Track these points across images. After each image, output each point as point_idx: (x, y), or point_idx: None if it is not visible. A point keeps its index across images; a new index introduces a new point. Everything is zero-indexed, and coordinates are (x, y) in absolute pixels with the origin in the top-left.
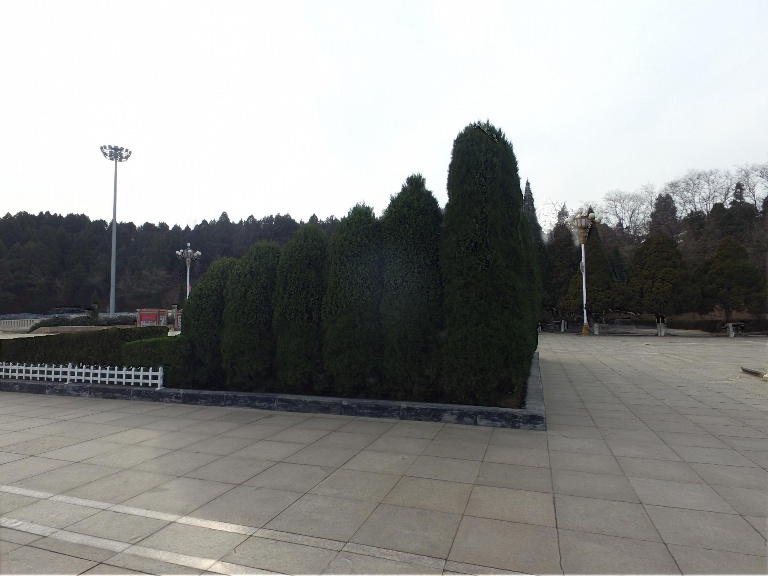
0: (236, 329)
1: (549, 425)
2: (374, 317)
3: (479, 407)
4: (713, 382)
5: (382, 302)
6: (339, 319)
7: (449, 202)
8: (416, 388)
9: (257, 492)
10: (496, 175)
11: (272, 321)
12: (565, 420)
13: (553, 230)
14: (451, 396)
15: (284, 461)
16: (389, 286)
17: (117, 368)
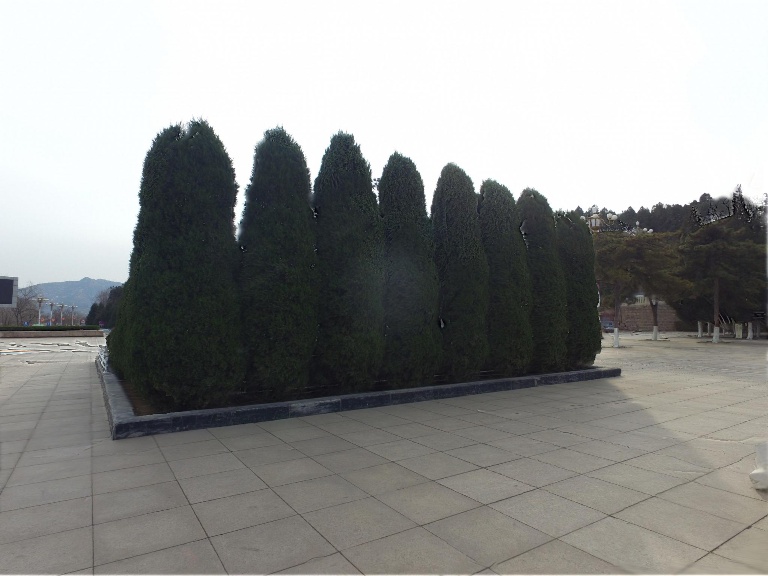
0: None
1: (143, 437)
2: None
3: (123, 409)
4: (673, 436)
5: None
6: None
7: None
8: None
9: None
10: (159, 176)
11: None
12: (180, 436)
13: None
14: None
15: None
16: None
17: None
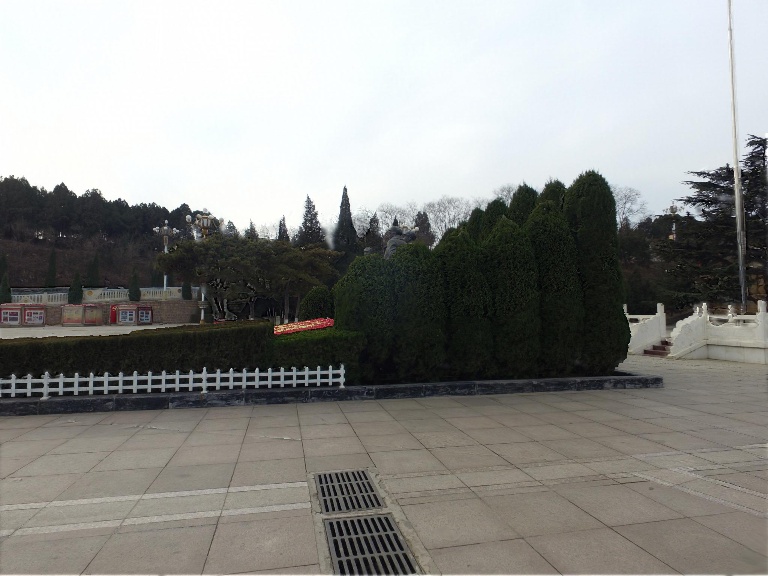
0: (424, 324)
1: None
2: (538, 313)
3: None
4: None
5: (546, 301)
6: (519, 315)
7: (587, 228)
8: (569, 367)
9: (703, 432)
10: None
11: (451, 316)
12: None
13: (366, 235)
14: (587, 371)
15: (638, 418)
16: (551, 289)
17: (284, 369)
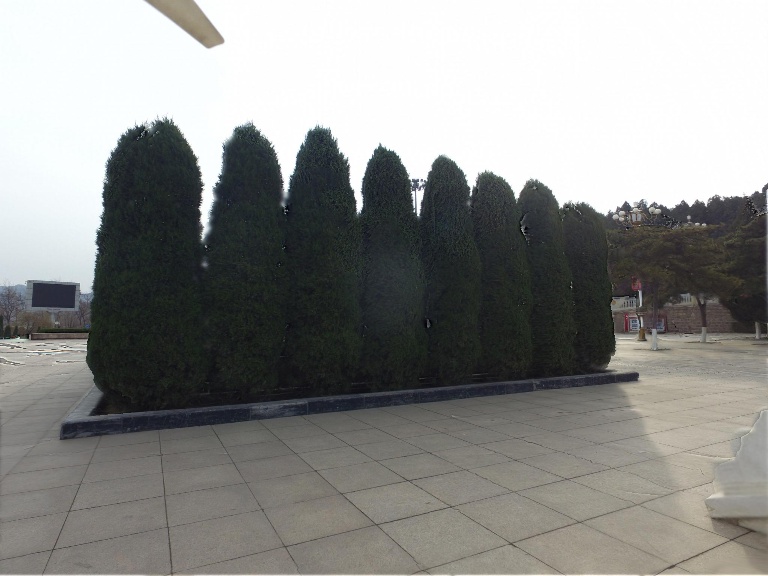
0: None
1: (91, 437)
2: None
3: None
4: (652, 450)
5: None
6: None
7: None
8: None
9: None
10: (119, 176)
11: None
12: None
13: None
14: None
15: None
16: None
17: None
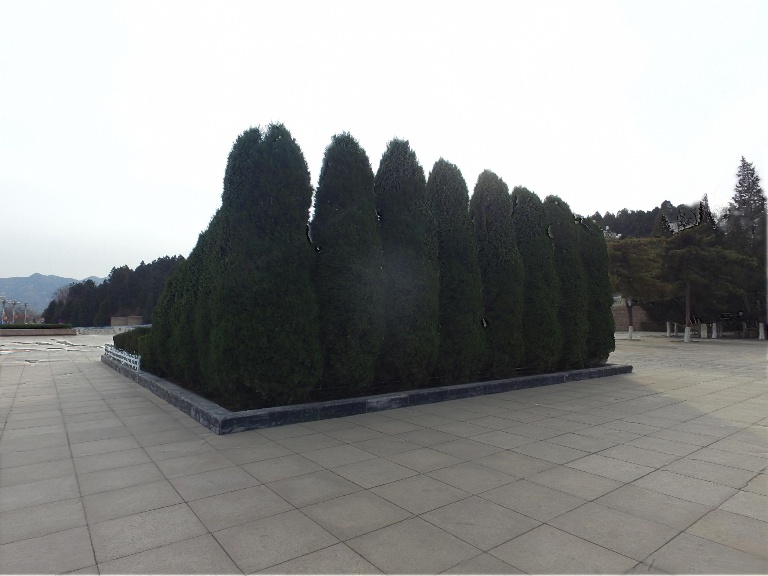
0: None
1: (245, 432)
2: None
3: None
4: (729, 424)
5: None
6: None
7: None
8: (209, 384)
9: None
10: (245, 177)
11: None
12: (281, 431)
13: None
14: None
15: None
16: None
17: (130, 355)
